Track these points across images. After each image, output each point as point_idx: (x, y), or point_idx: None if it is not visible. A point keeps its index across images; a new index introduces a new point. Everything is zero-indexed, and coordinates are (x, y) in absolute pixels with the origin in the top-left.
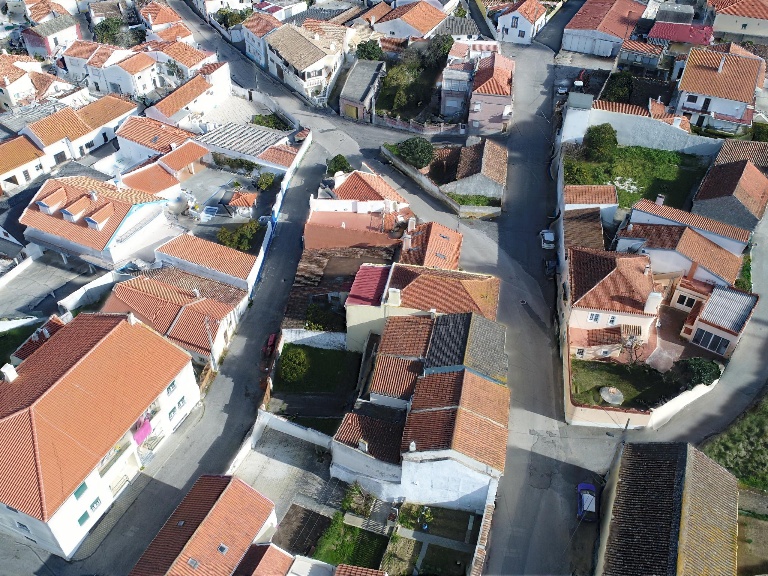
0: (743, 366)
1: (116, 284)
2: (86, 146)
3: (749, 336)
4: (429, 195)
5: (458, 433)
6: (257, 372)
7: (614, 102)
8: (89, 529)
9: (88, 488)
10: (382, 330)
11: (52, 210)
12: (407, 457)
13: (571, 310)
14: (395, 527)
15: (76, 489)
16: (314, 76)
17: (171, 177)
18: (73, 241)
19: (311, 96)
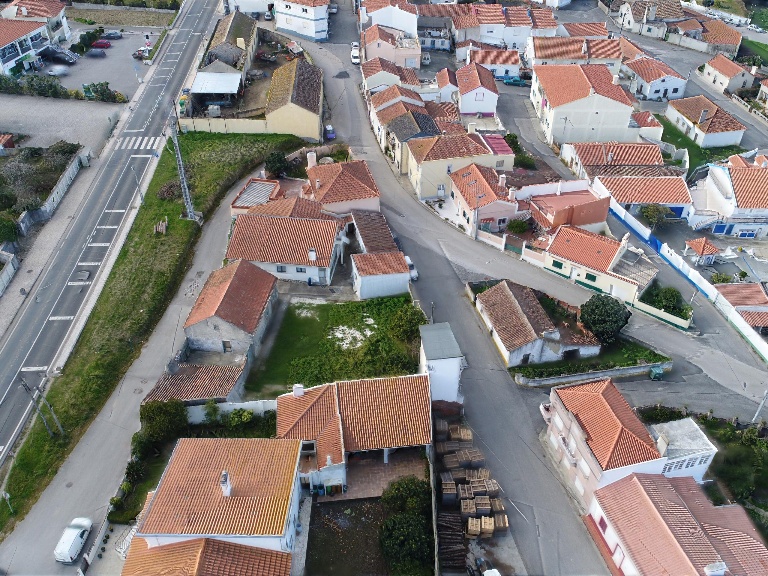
0: None
1: None
2: None
3: None
4: None
5: None
6: None
7: None
8: None
9: None
10: None
11: None
12: None
13: None
14: None
15: None
16: None
17: None
18: None
19: None
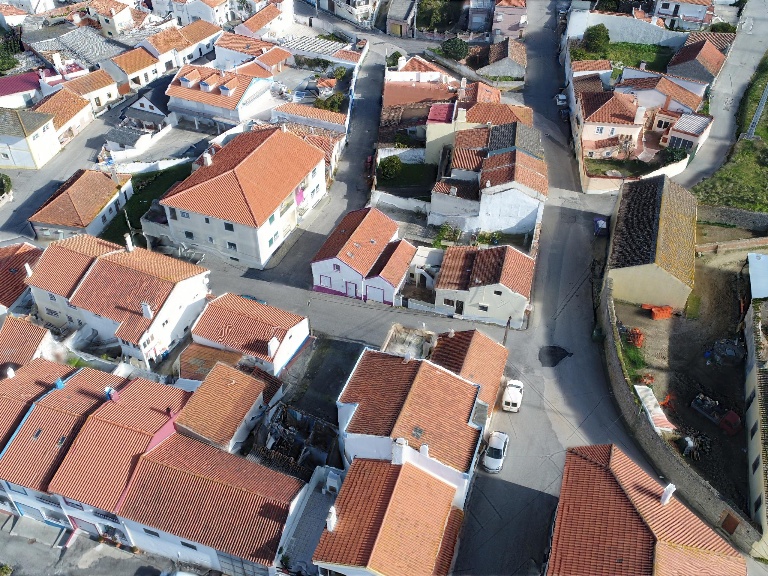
0: (703, 160)
1: (253, 125)
2: (188, 57)
3: (707, 145)
4: (467, 79)
5: (517, 175)
6: (362, 179)
7: (606, 11)
8: (272, 253)
9: (275, 220)
10: (454, 138)
11: (191, 84)
12: (485, 192)
13: (584, 125)
14: (476, 244)
15: (271, 215)
16: (363, 5)
17: (266, 71)
18: (210, 104)
19: (361, 21)
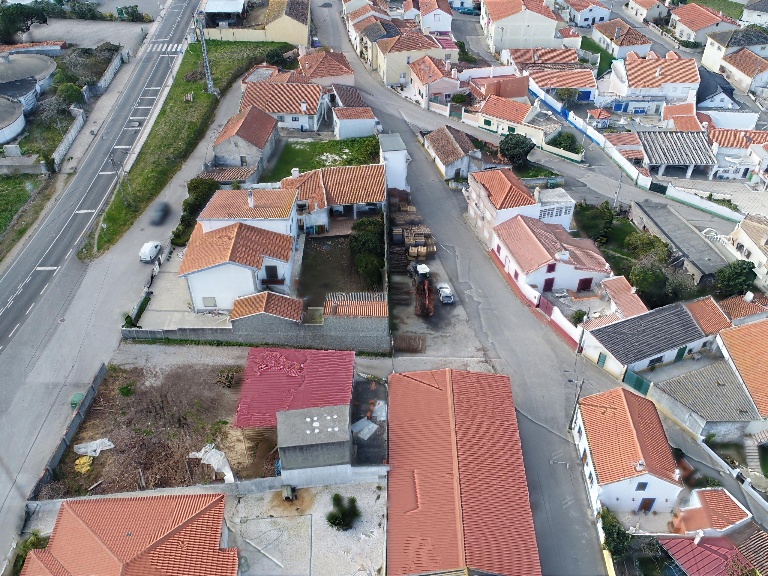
0: None
1: None
2: None
3: None
4: None
5: None
6: None
7: None
8: None
9: None
10: None
11: None
12: None
13: None
14: None
15: None
16: None
17: None
18: None
19: None
